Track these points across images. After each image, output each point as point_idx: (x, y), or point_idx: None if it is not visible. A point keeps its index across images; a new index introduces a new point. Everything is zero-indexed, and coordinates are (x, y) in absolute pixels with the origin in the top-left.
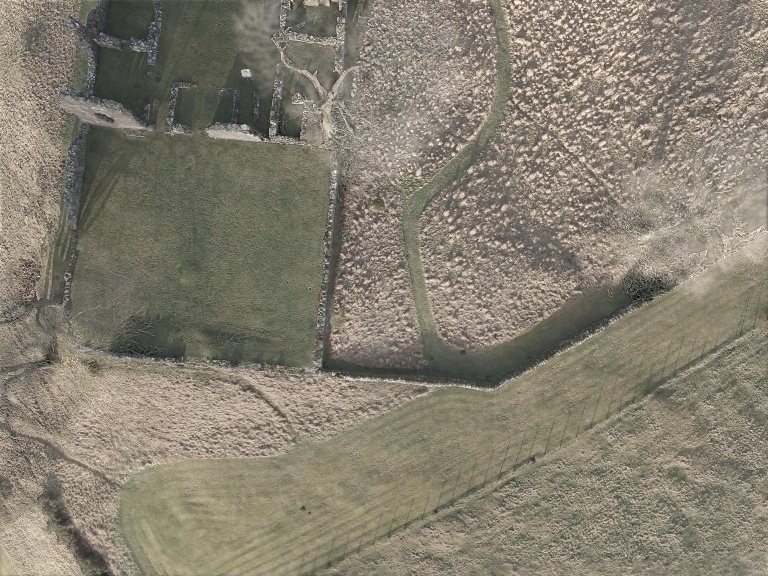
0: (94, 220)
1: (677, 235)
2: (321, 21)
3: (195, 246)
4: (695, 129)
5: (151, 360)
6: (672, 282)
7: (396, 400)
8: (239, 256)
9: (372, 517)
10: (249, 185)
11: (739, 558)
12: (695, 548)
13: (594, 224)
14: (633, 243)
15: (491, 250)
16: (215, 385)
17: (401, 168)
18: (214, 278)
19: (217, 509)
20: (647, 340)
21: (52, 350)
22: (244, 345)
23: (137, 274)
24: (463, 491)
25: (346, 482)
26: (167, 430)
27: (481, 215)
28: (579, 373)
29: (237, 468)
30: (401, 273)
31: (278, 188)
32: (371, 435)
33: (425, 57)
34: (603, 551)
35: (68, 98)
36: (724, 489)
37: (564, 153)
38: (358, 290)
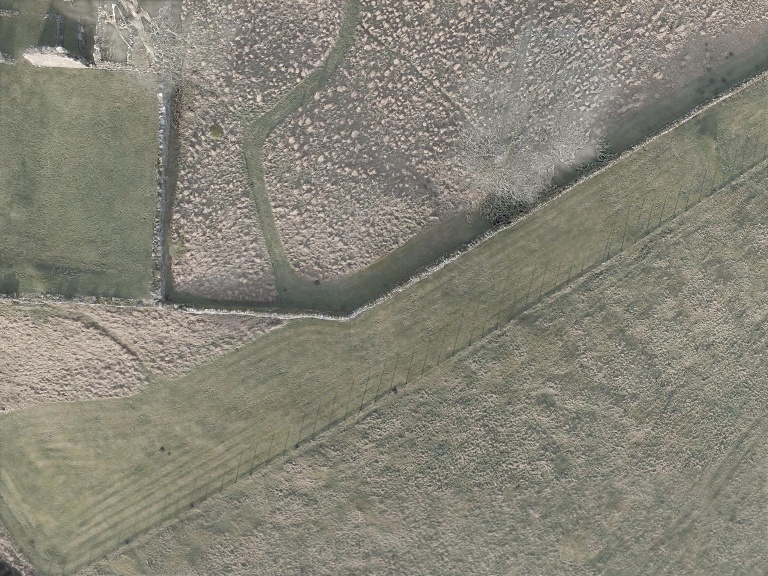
0: None
1: (537, 158)
2: None
3: (25, 179)
4: (555, 51)
5: None
6: (531, 205)
7: (250, 334)
8: (71, 188)
9: (233, 455)
10: (78, 114)
11: (614, 484)
12: (567, 475)
13: (449, 148)
14: (490, 166)
15: (341, 177)
16: (55, 322)
17: (240, 94)
18: (46, 211)
19: (75, 454)
20: (509, 265)
21: None
22: (79, 278)
23: None
24: (324, 425)
25: (204, 420)
26: (15, 374)
27: (330, 142)
28: (438, 300)
29: (91, 410)
30: (245, 202)
31: (108, 116)
32: (226, 371)
33: None
34: (472, 481)
35: None
36: (595, 414)
37: (417, 77)
38: (197, 219)
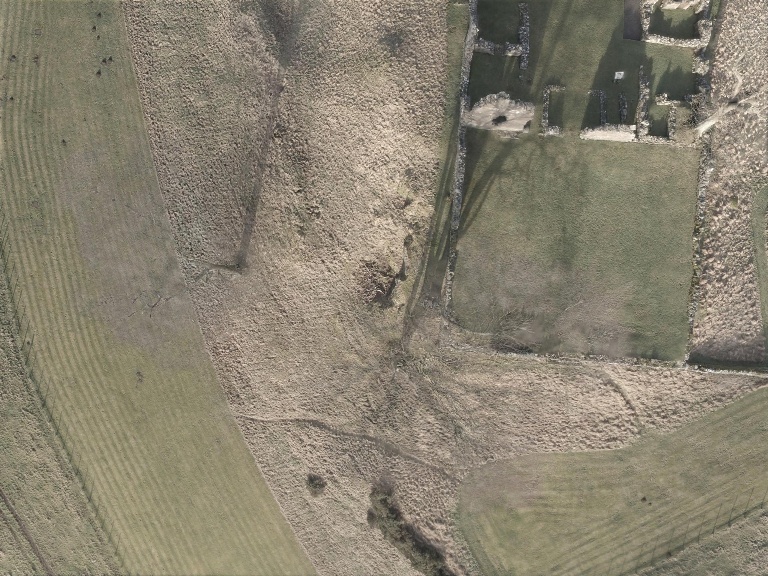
0: (472, 220)
1: None
2: (678, 24)
3: (565, 244)
4: None
5: (534, 356)
6: None
7: (739, 392)
8: (608, 253)
9: (712, 507)
10: (616, 184)
11: None
12: None
13: None
14: None
15: None
16: (580, 380)
17: (751, 166)
18: (583, 275)
19: (557, 502)
20: None
21: (402, 349)
22: (617, 340)
23: (511, 272)
24: None
25: (688, 473)
26: (518, 425)
27: None
28: None
29: (581, 461)
30: (751, 268)
31: (645, 187)
32: (714, 426)
33: (762, 58)
34: None
35: (505, 101)
36: None
37: None
38: (719, 285)
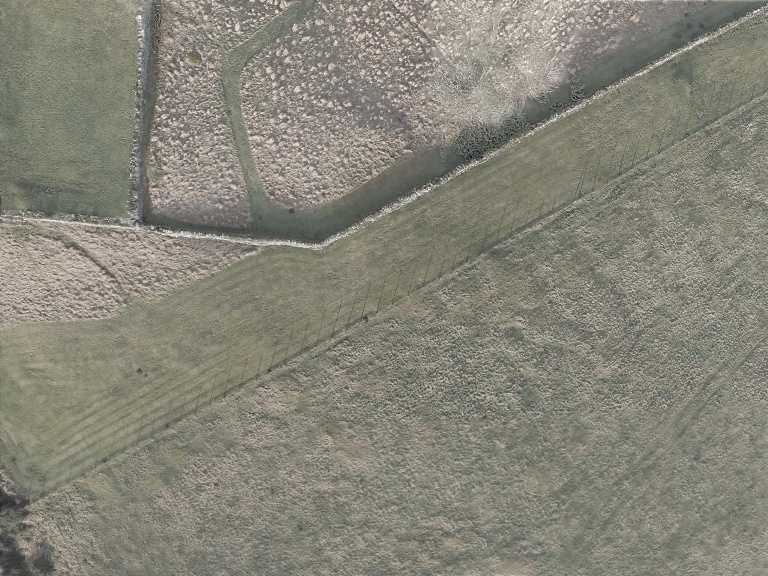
0: None
1: (512, 96)
2: None
3: (8, 100)
4: None
5: None
6: (504, 141)
7: (225, 259)
8: (52, 109)
9: (207, 378)
10: (60, 37)
11: (579, 418)
12: (533, 407)
13: (425, 84)
14: (464, 102)
15: (317, 108)
16: (36, 241)
17: (218, 22)
18: (28, 132)
19: (56, 374)
20: (481, 201)
21: None
22: (59, 197)
23: None
24: (296, 350)
25: (180, 343)
26: None
27: (307, 73)
28: (410, 232)
29: (72, 331)
30: (222, 129)
31: (89, 39)
32: (202, 295)
33: None
34: (439, 410)
35: None
36: (563, 350)
37: (394, 13)
38: (175, 143)
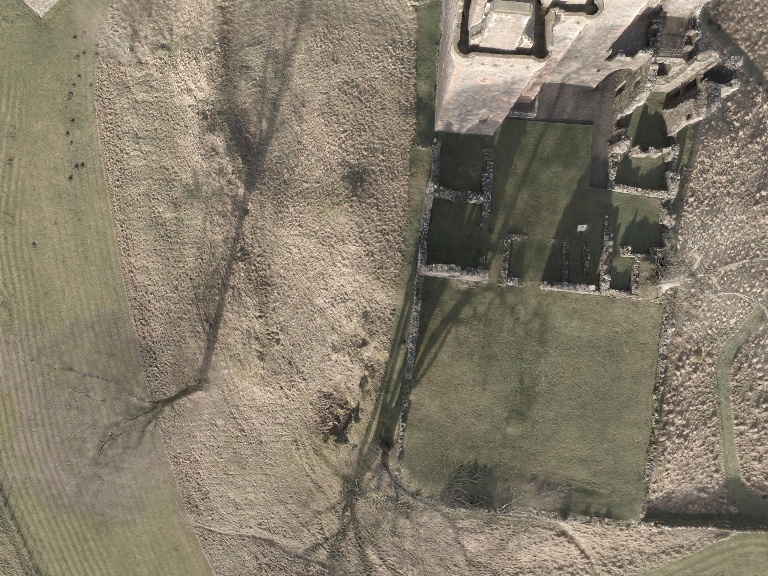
0: (427, 370)
1: None
2: (646, 172)
3: (521, 395)
4: None
5: (484, 512)
6: None
7: (698, 544)
8: (565, 406)
9: None
10: (576, 336)
11: None
12: None
13: None
14: None
15: None
16: (533, 531)
17: (718, 317)
18: (539, 427)
19: None
20: None
21: (355, 485)
22: (571, 496)
23: (465, 423)
24: None
25: None
26: (470, 568)
27: None
28: None
29: None
30: (714, 421)
31: (606, 340)
32: None
33: (735, 203)
34: None
35: None
36: None
37: None
38: (679, 441)
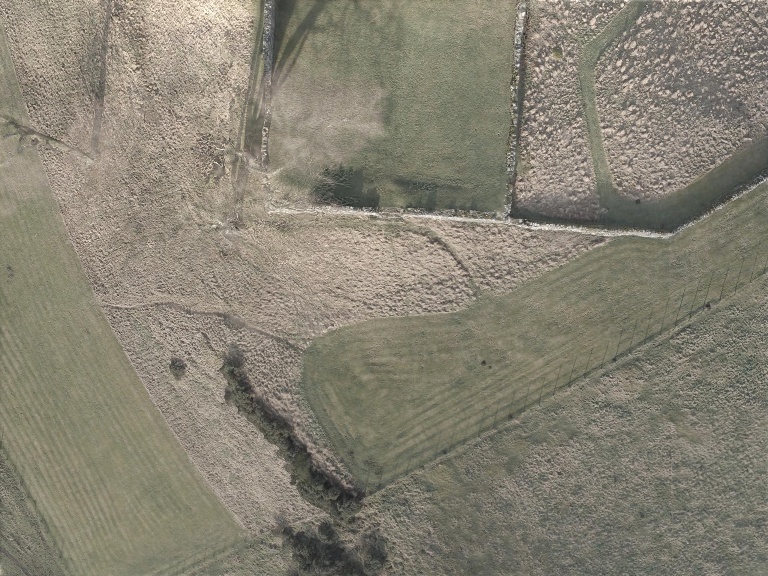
0: (286, 76)
1: None
2: None
3: (383, 99)
4: None
5: (350, 209)
6: None
7: (574, 251)
8: (426, 107)
9: (552, 368)
10: (433, 37)
11: None
12: None
13: (760, 72)
14: None
15: (662, 99)
16: (405, 237)
17: (577, 17)
18: (402, 130)
19: (399, 368)
20: None
21: (236, 217)
22: (436, 193)
23: (329, 129)
24: (640, 339)
25: (526, 335)
26: (352, 289)
27: (651, 65)
28: (751, 219)
29: (419, 326)
30: (579, 122)
31: (462, 38)
32: (550, 287)
33: None
34: None
35: None
36: None
37: (727, 3)
38: (542, 137)
